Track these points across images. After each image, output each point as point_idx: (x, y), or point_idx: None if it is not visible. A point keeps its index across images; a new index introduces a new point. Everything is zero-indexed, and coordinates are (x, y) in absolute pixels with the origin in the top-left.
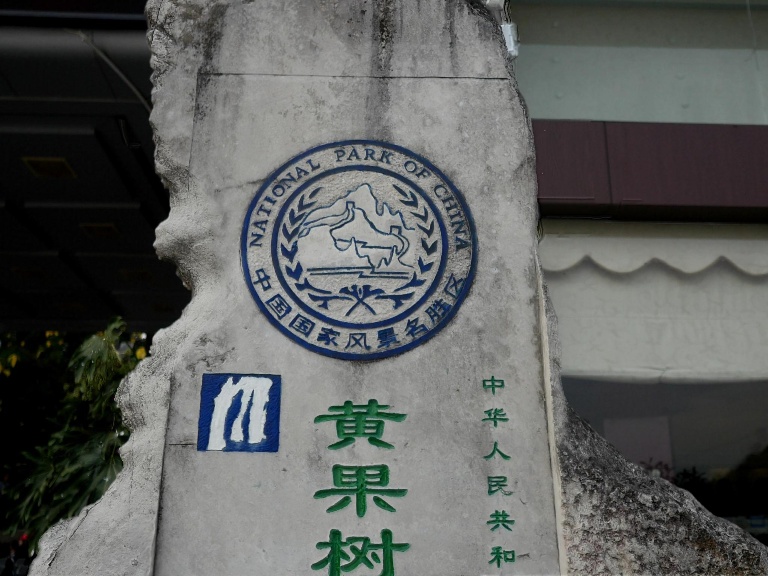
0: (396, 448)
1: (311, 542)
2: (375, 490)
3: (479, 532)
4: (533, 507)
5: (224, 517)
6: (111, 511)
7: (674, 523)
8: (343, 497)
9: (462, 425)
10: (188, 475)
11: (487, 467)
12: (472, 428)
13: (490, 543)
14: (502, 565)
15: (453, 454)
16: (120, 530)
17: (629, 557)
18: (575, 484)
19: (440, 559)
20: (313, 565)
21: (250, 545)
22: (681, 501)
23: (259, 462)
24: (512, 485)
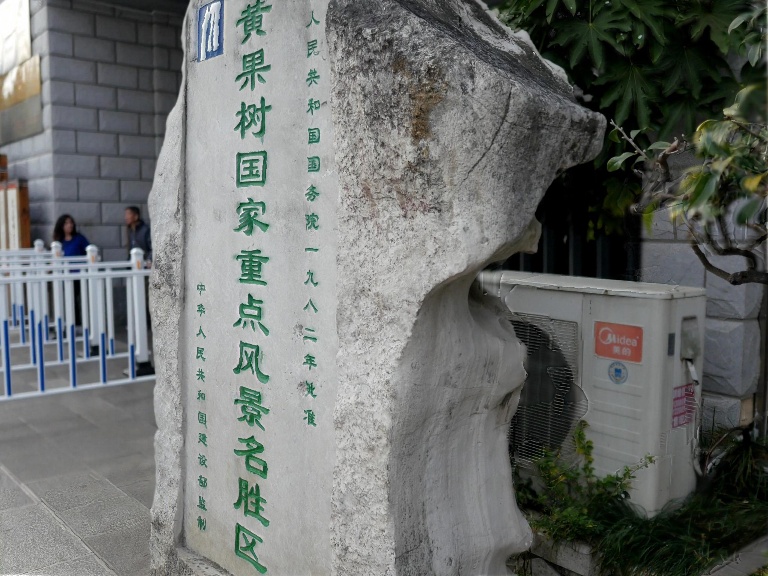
0: (267, 34)
1: (234, 113)
2: (258, 69)
3: (302, 89)
4: None
5: (207, 103)
6: None
7: (384, 51)
8: None
9: (296, 3)
10: (195, 79)
11: (308, 34)
12: (301, 4)
13: (307, 97)
14: (313, 113)
15: (291, 29)
16: None
17: (358, 90)
18: (333, 33)
19: (284, 114)
20: (235, 128)
21: (214, 119)
22: (400, 29)
23: (217, 63)
24: (319, 46)
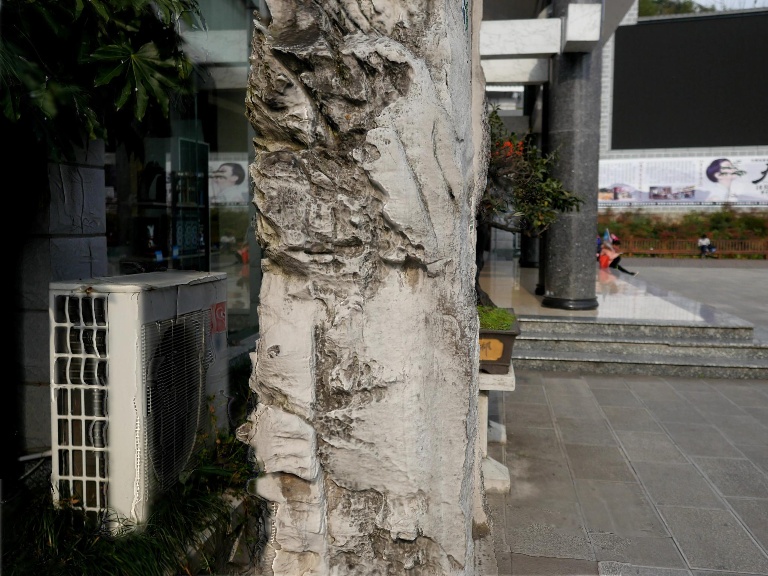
0: None
1: None
2: None
3: None
4: None
5: None
6: None
7: None
8: None
9: None
10: None
11: None
12: None
13: None
14: None
15: None
16: None
17: None
18: None
19: None
20: None
21: None
22: None
23: None
24: None
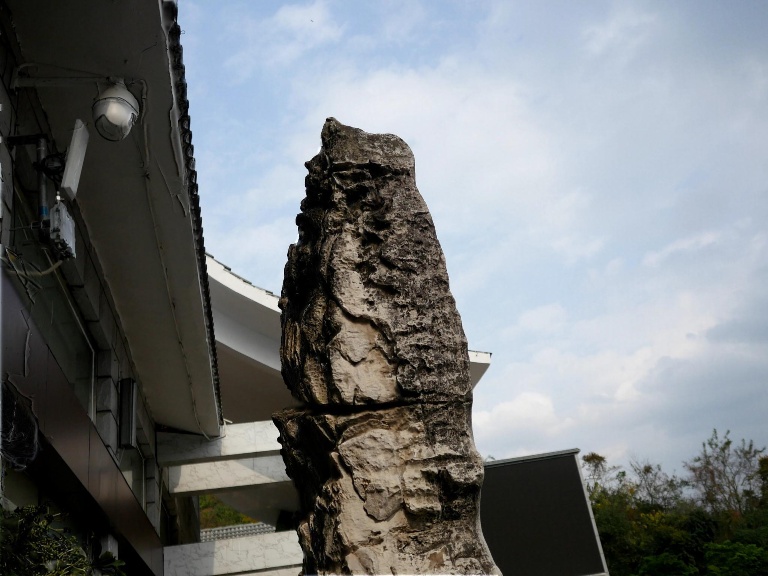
0: None
1: None
2: None
3: None
4: None
5: None
6: None
7: None
8: None
9: None
10: None
11: None
12: None
13: None
14: None
15: None
16: None
17: None
18: None
19: None
20: None
21: None
22: None
23: None
24: None
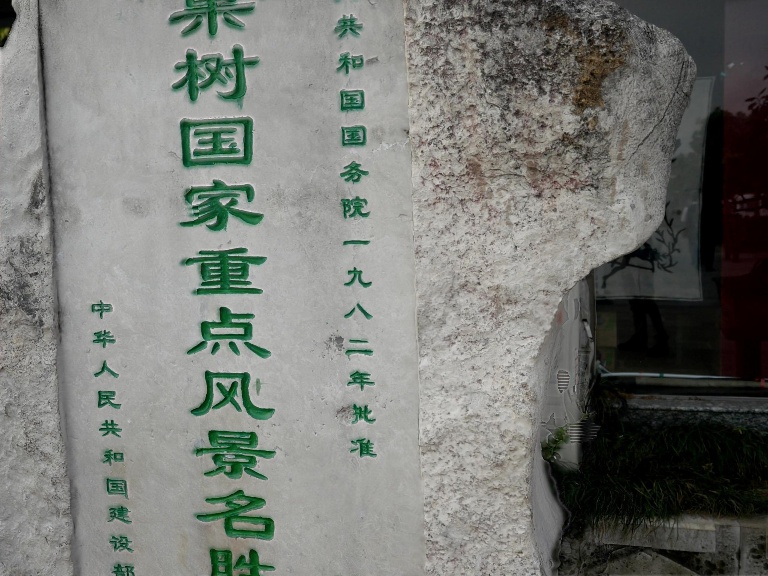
0: None
1: (170, 63)
2: (224, 6)
3: (326, 39)
4: (382, 7)
5: (95, 47)
6: (6, 51)
7: (524, 3)
8: (196, 17)
9: None
10: (61, 11)
11: None
12: None
13: (338, 49)
14: (350, 71)
15: None
16: (12, 66)
17: (471, 46)
18: None
19: (289, 69)
20: (174, 84)
21: (119, 70)
22: None
23: None
24: None
